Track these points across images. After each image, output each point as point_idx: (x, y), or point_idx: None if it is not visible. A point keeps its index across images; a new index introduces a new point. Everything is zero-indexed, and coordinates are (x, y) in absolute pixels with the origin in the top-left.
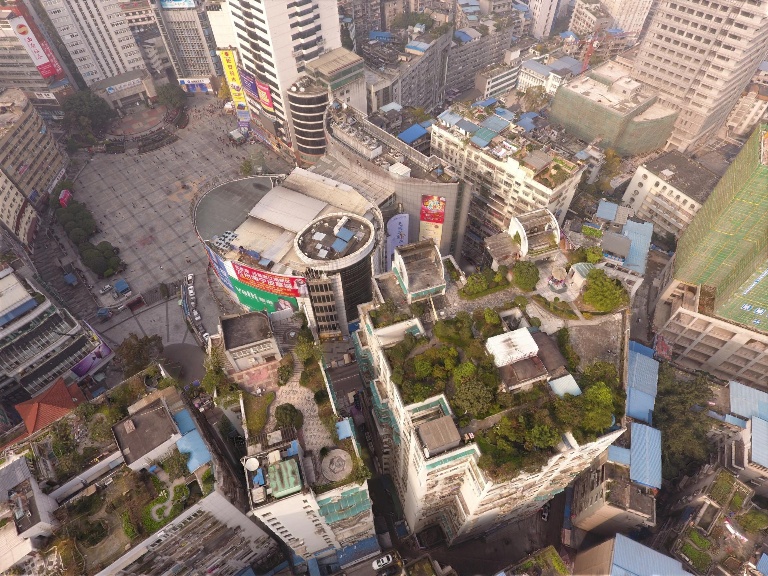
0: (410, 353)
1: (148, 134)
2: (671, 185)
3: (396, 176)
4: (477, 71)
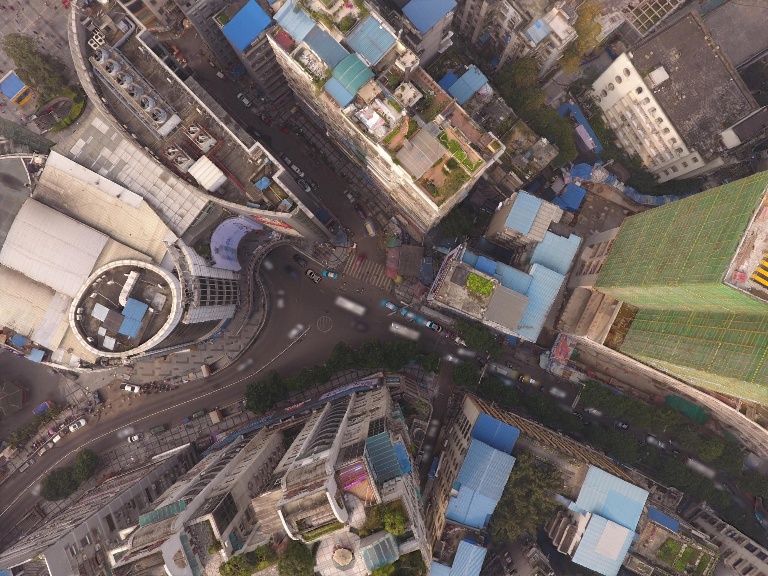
0: None
1: None
2: (656, 101)
3: None
4: None
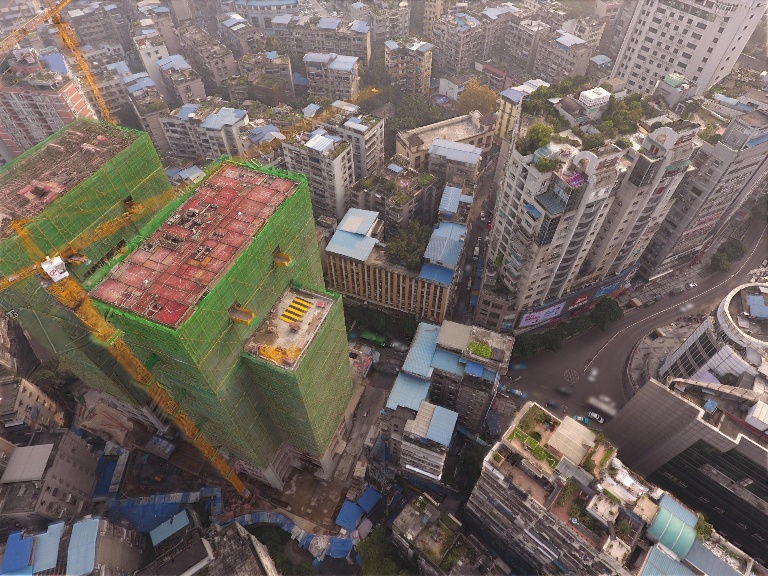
0: None
1: None
2: None
3: (765, 397)
4: None
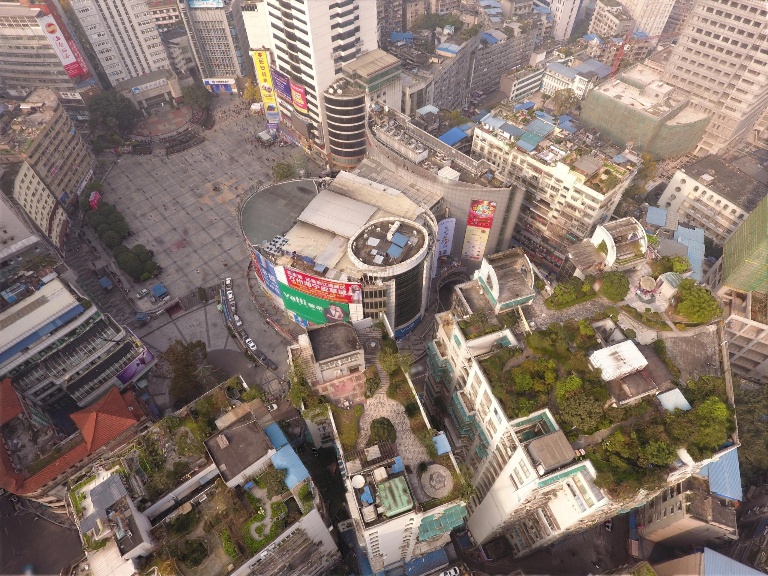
0: (505, 365)
1: (175, 135)
2: (711, 190)
3: (446, 180)
4: (501, 73)
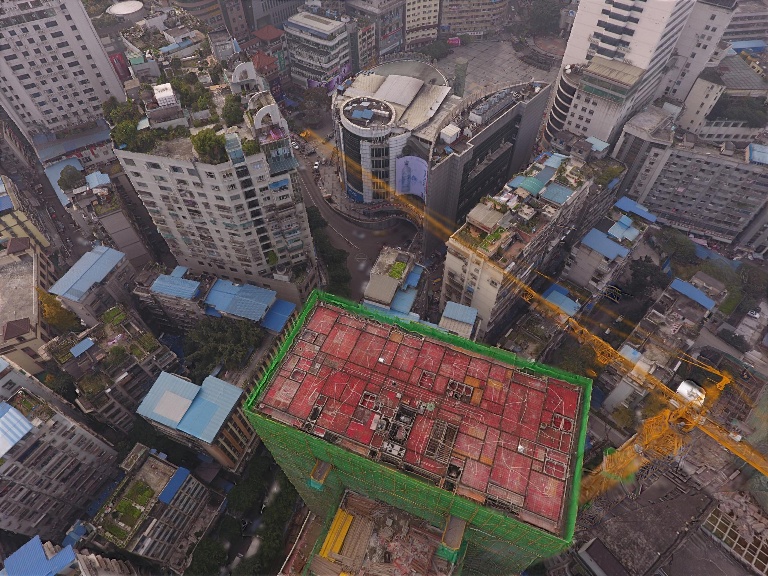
0: (192, 85)
1: (542, 54)
2: None
3: None
4: None
